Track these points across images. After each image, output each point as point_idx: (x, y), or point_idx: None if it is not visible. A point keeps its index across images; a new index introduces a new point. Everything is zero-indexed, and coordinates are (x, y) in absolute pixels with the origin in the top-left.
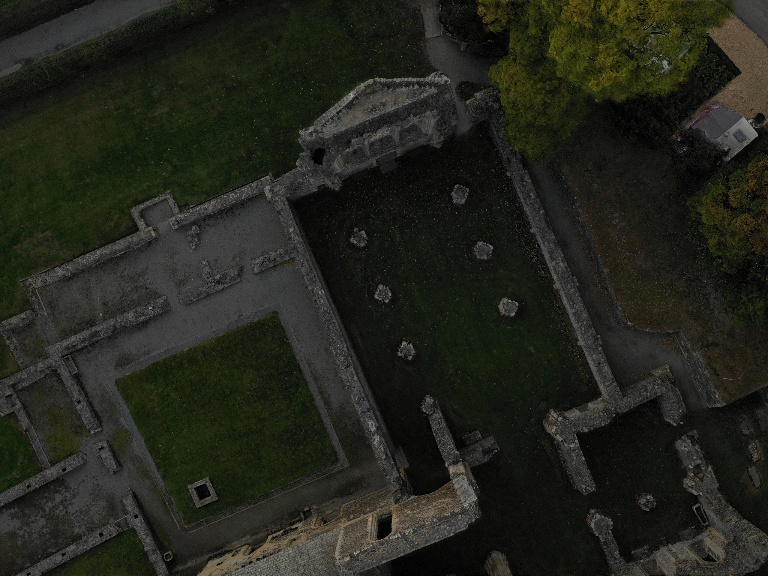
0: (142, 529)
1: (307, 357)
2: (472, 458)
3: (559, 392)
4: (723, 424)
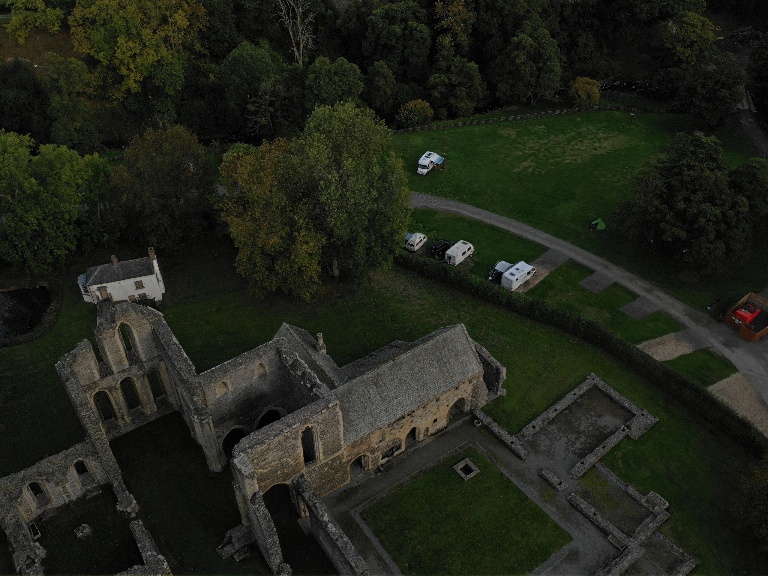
0: (504, 436)
1: None
2: (241, 531)
3: None
4: None
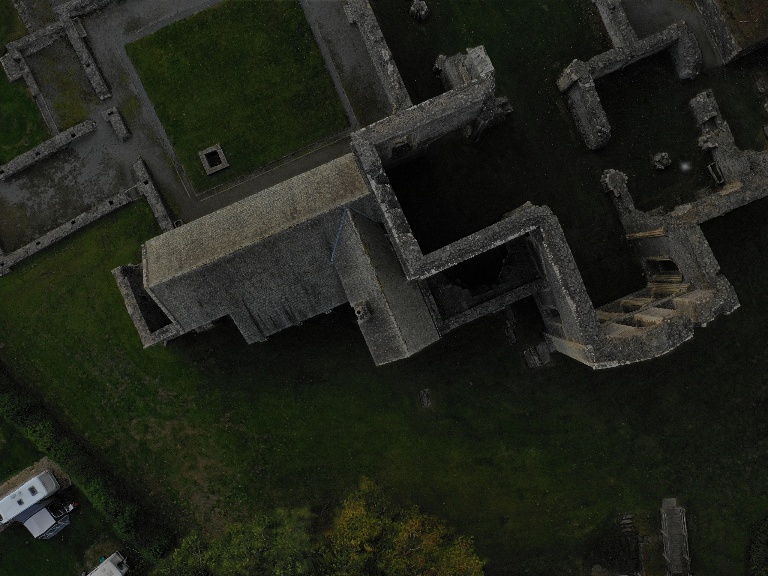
0: (152, 195)
1: (318, 19)
2: None
3: (573, 51)
4: (739, 82)
